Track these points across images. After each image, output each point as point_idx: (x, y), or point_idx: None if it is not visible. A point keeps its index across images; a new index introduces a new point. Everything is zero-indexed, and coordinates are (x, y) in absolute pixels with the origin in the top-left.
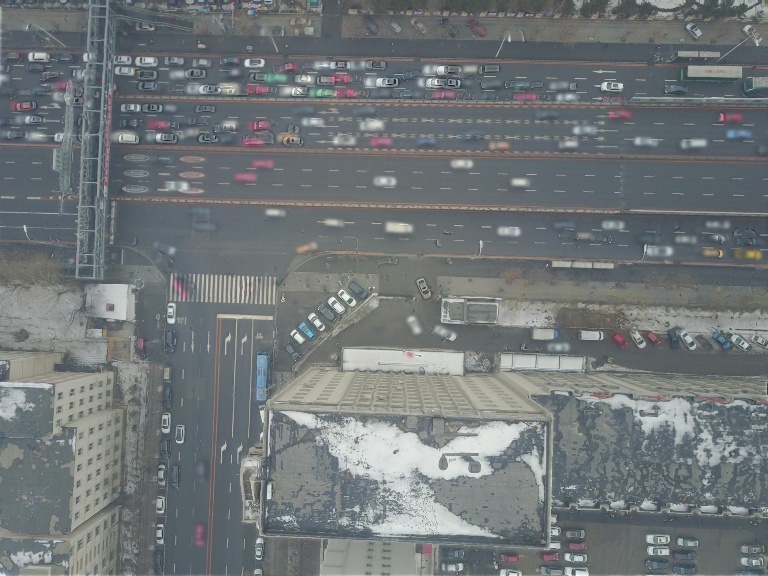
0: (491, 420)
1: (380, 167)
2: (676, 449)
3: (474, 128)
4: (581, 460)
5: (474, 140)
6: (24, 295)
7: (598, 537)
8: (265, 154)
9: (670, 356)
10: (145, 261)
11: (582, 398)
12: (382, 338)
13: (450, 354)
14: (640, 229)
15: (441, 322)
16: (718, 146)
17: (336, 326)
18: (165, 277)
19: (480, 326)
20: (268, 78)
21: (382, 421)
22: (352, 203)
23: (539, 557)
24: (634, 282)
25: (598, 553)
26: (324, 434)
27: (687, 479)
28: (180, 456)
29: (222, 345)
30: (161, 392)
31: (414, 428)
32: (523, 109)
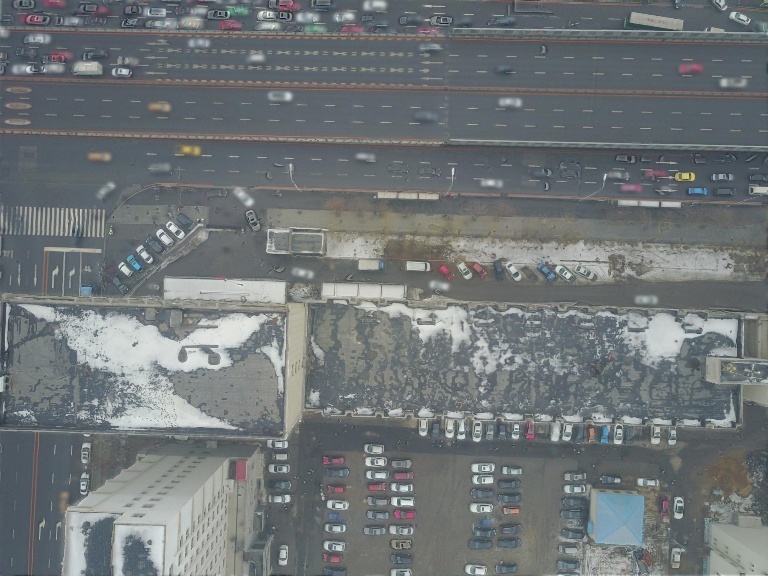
0: (232, 312)
1: (209, 98)
2: (453, 357)
3: (302, 60)
4: (360, 369)
5: (302, 72)
6: None
7: (425, 467)
8: (94, 85)
9: (496, 287)
10: None
11: (360, 307)
12: (211, 270)
13: (272, 283)
14: (468, 162)
15: (268, 253)
16: (540, 78)
17: (164, 258)
18: None
19: (309, 258)
20: (98, 9)
21: (122, 314)
22: (181, 135)
23: (366, 488)
24: (462, 214)
25: (425, 483)
26: (63, 327)
27: (464, 387)
28: None
29: (49, 278)
30: None
31: (153, 320)
32: (351, 41)
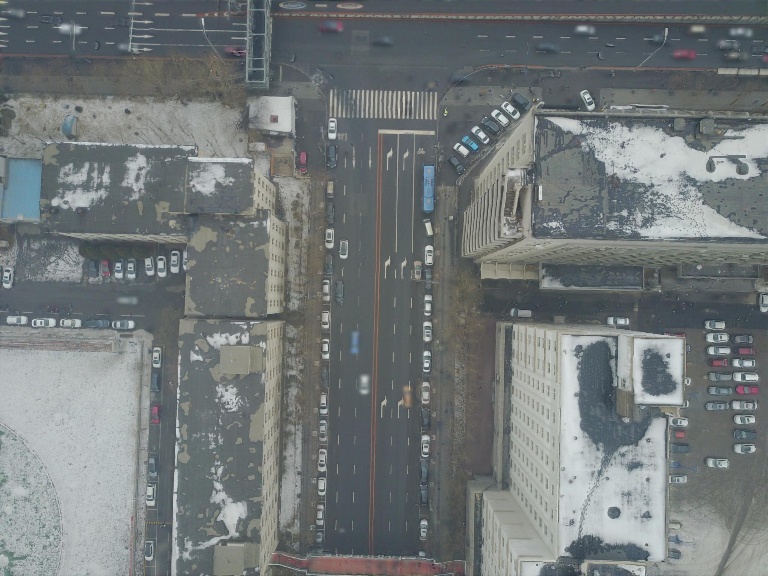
0: (757, 123)
1: None
2: None
3: None
4: None
5: None
6: (182, 111)
7: (765, 343)
8: None
9: None
10: (304, 77)
11: None
12: None
13: None
14: None
15: None
16: None
17: (500, 139)
18: (324, 93)
19: None
20: None
21: (648, 126)
22: (515, 15)
23: (707, 364)
24: None
25: (765, 359)
26: (590, 140)
27: None
28: (343, 272)
29: (384, 161)
30: (323, 208)
31: (681, 131)
32: None
